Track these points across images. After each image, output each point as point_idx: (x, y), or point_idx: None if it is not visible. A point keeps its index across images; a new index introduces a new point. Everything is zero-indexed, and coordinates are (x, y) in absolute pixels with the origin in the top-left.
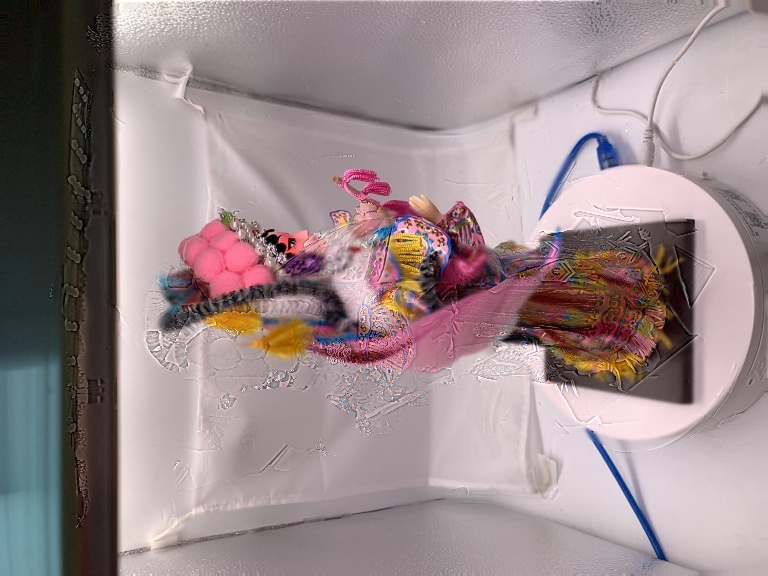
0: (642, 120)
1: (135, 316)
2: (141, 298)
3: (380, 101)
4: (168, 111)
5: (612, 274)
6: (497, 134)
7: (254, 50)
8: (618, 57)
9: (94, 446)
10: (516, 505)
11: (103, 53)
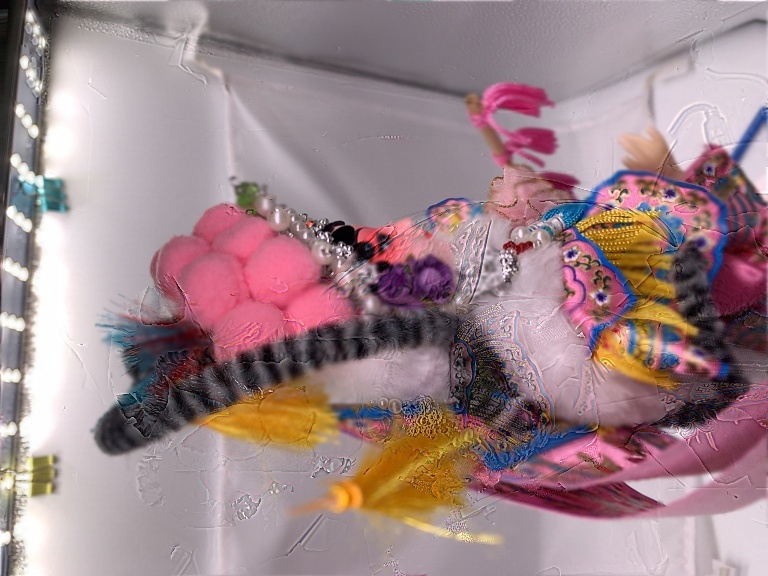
0: (764, 85)
1: (99, 364)
2: (107, 336)
3: (432, 65)
4: (161, 82)
5: None
6: (575, 108)
7: (270, 0)
8: (734, 5)
9: (37, 569)
10: None
11: (75, 7)
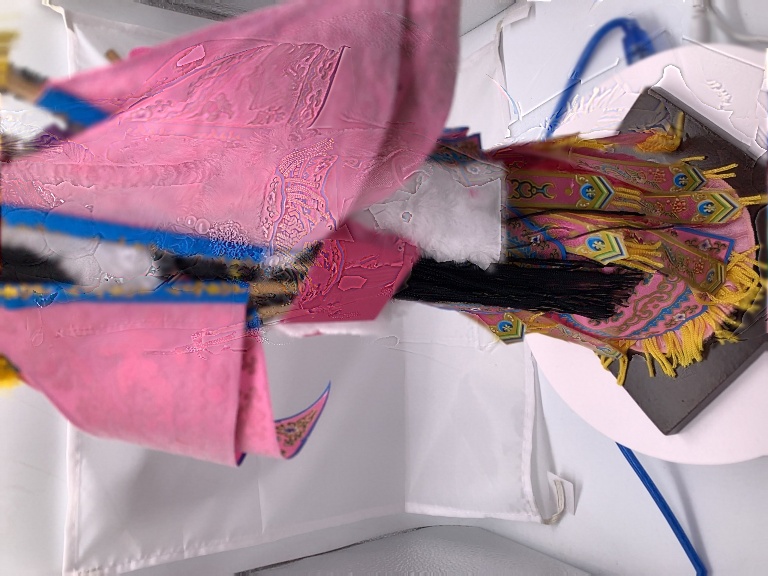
0: None
1: None
2: None
3: None
4: None
5: (685, 253)
6: None
7: None
8: None
9: None
10: (448, 356)
11: None
